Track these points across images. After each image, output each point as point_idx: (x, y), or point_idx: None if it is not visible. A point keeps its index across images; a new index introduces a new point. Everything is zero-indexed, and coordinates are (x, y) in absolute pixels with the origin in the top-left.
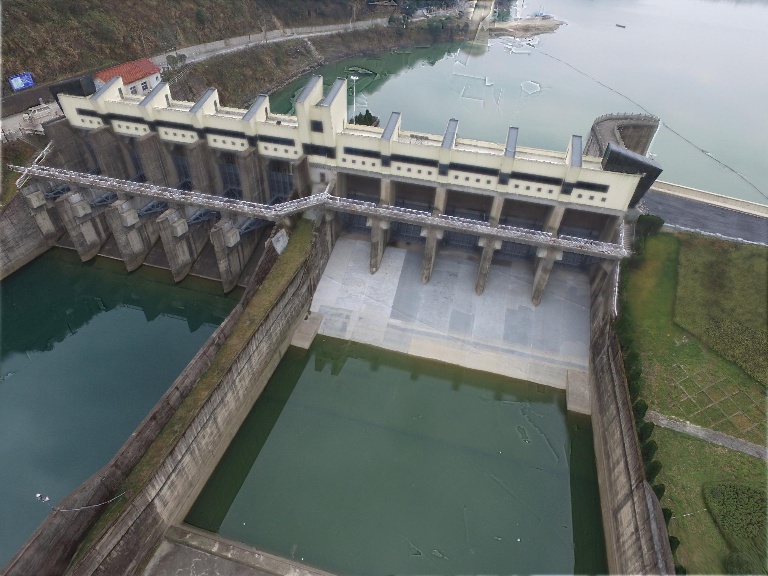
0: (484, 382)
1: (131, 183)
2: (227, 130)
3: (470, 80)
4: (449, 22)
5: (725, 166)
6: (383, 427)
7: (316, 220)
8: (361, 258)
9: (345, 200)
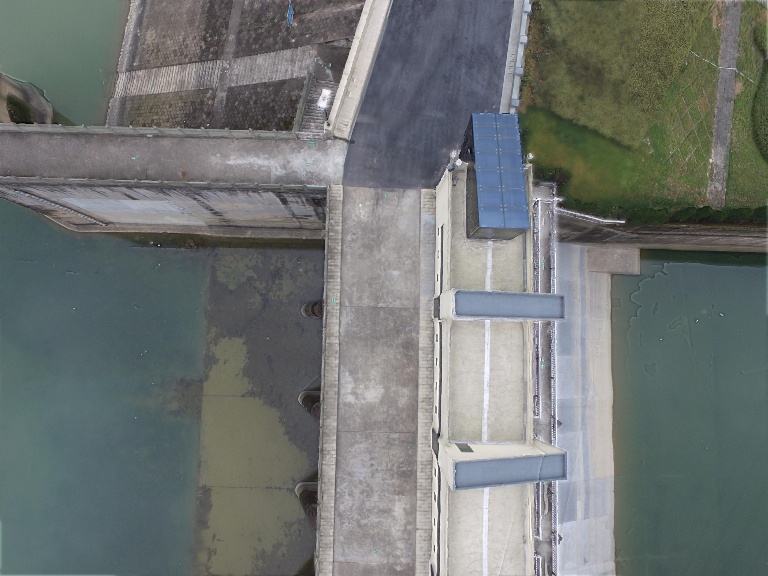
0: (624, 371)
1: None
2: None
3: None
4: None
5: None
6: (717, 479)
7: None
8: None
9: None
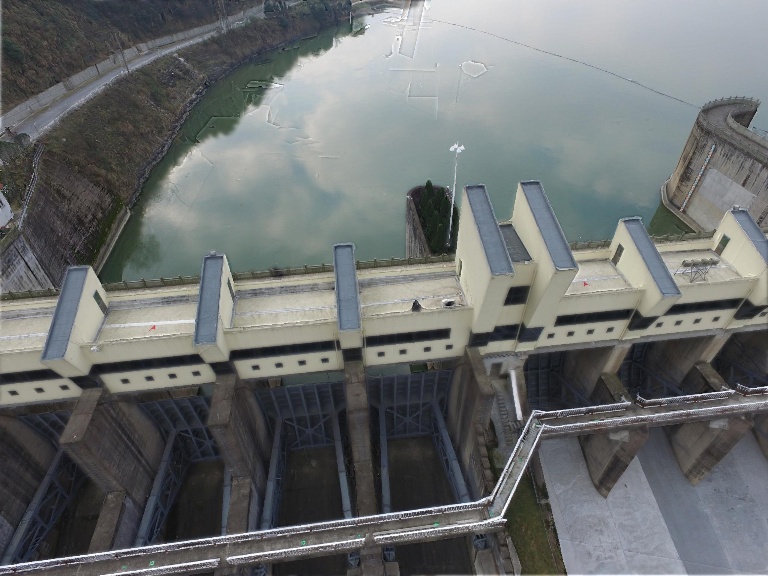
0: None
1: (92, 556)
2: (287, 345)
3: (415, 75)
4: (329, 1)
5: (765, 132)
6: None
7: (530, 469)
8: (566, 468)
9: (572, 411)
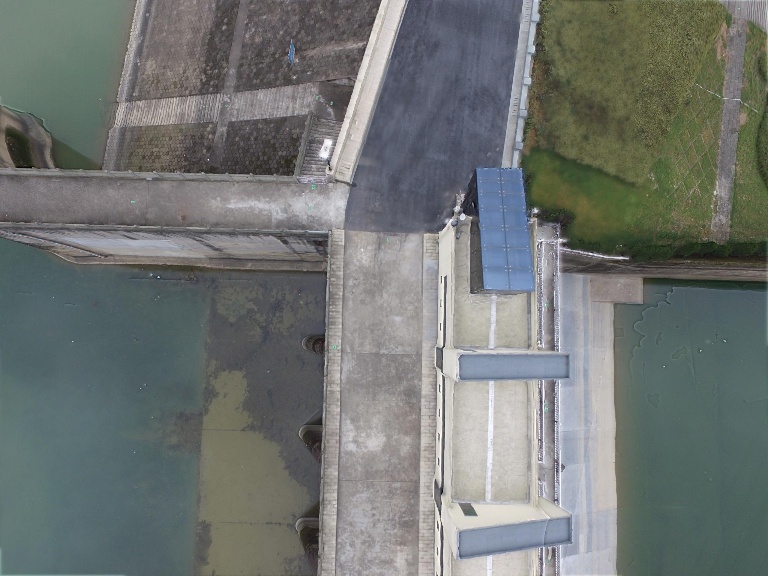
0: (627, 402)
1: None
2: None
3: None
4: None
5: None
6: (721, 510)
7: None
8: None
9: None
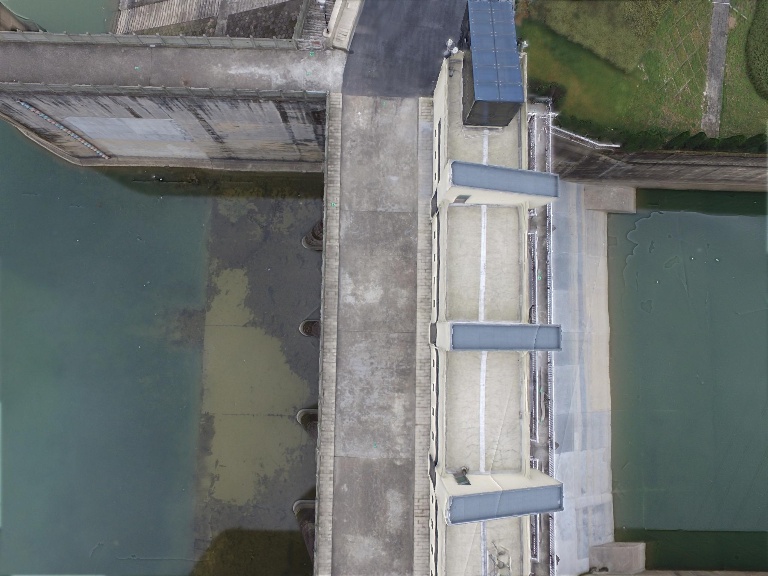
0: (621, 309)
1: None
2: None
3: None
4: None
5: None
6: (713, 414)
7: None
8: None
9: None
